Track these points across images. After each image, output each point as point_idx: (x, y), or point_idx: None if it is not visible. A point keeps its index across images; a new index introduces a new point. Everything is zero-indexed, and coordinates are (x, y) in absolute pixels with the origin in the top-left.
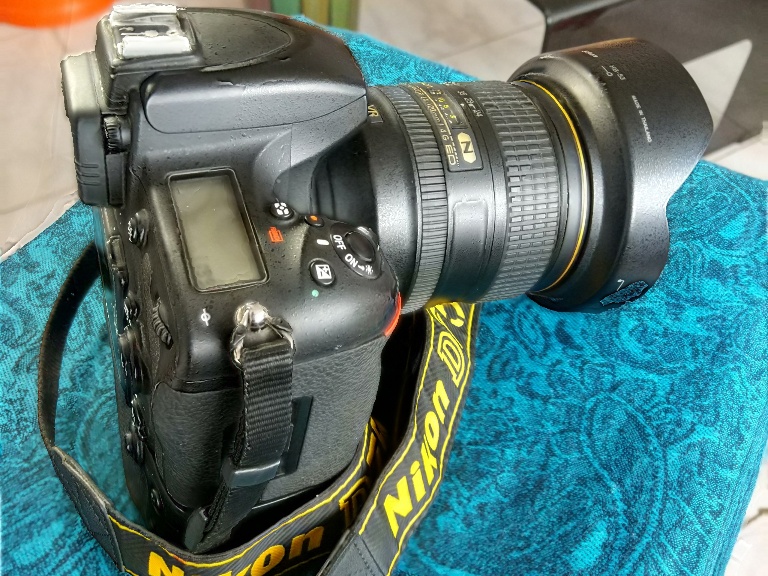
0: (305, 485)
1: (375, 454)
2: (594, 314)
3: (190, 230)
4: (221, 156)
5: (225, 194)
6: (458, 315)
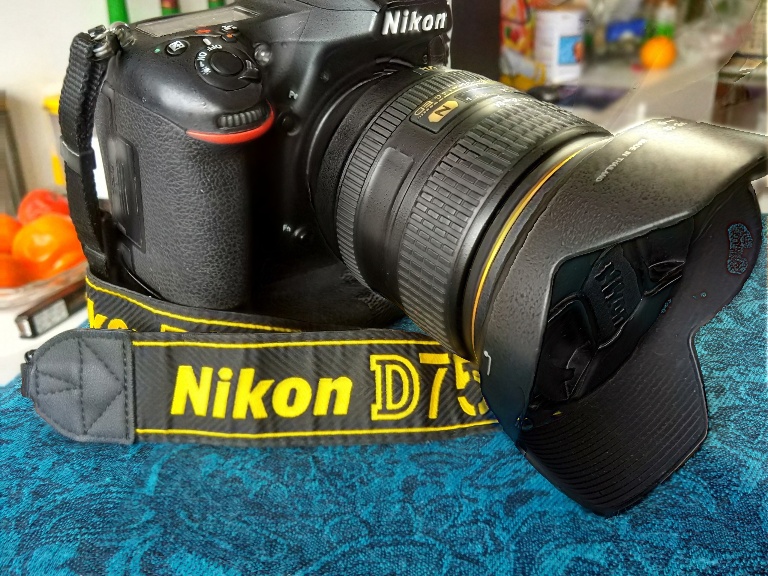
0: (156, 286)
1: None
2: (584, 518)
3: None
4: (265, 9)
5: None
6: (479, 405)
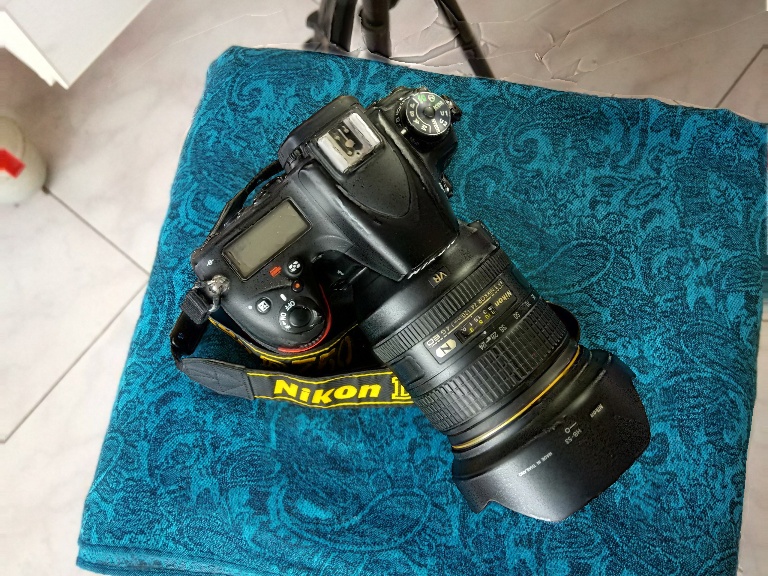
0: None
1: (305, 364)
2: None
3: (264, 226)
4: (316, 217)
5: (296, 231)
6: None
